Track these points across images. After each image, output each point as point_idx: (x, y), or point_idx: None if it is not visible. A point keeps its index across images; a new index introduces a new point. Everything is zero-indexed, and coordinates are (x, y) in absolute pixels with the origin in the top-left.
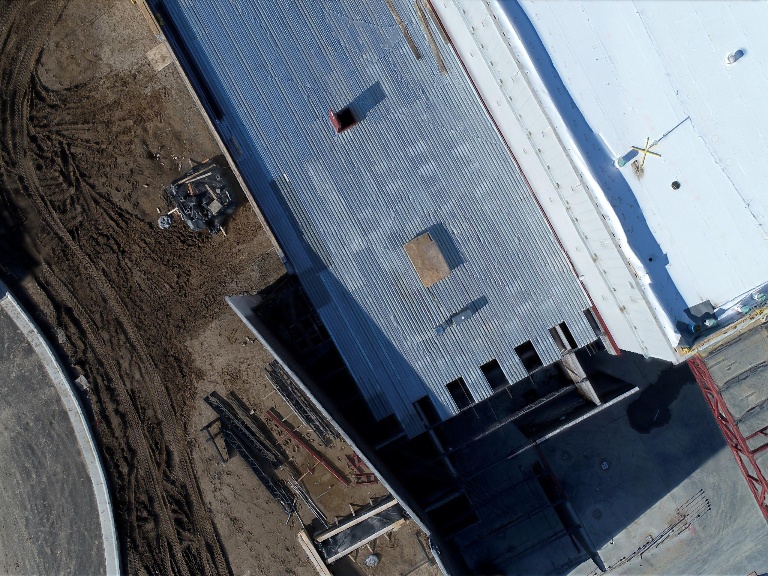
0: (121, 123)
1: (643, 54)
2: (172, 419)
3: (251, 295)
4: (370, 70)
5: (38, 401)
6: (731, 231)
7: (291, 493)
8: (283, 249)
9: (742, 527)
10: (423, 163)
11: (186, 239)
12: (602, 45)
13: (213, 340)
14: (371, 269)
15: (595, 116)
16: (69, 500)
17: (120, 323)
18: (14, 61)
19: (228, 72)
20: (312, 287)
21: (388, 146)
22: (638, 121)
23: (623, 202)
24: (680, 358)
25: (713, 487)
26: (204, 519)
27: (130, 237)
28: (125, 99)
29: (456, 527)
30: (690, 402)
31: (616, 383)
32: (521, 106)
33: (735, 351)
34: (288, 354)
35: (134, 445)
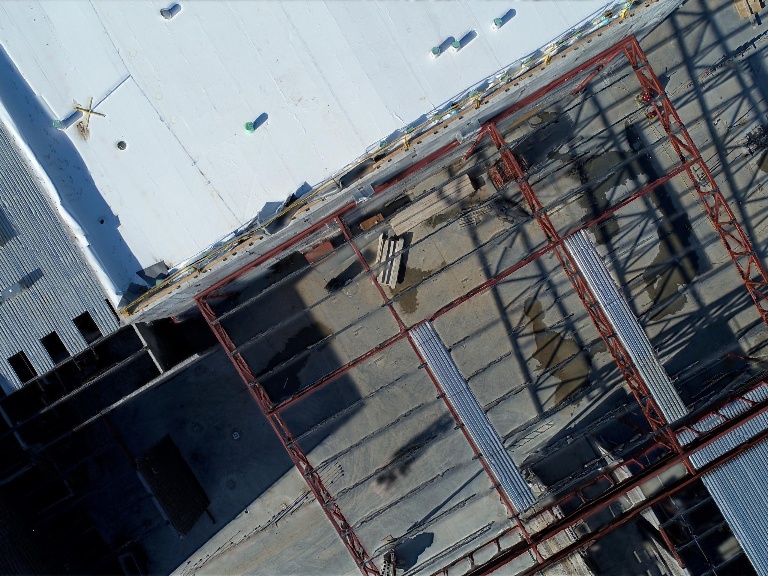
0: None
1: (81, 12)
2: None
3: None
4: None
5: None
6: (180, 190)
7: None
8: None
9: (376, 491)
10: None
11: None
12: (39, 5)
13: None
14: None
15: (36, 78)
16: None
17: None
18: None
19: None
20: None
21: None
22: (81, 81)
23: (70, 165)
24: (125, 320)
25: None
26: None
27: None
28: None
29: (45, 501)
30: (319, 369)
31: None
32: None
33: None
34: None
35: None
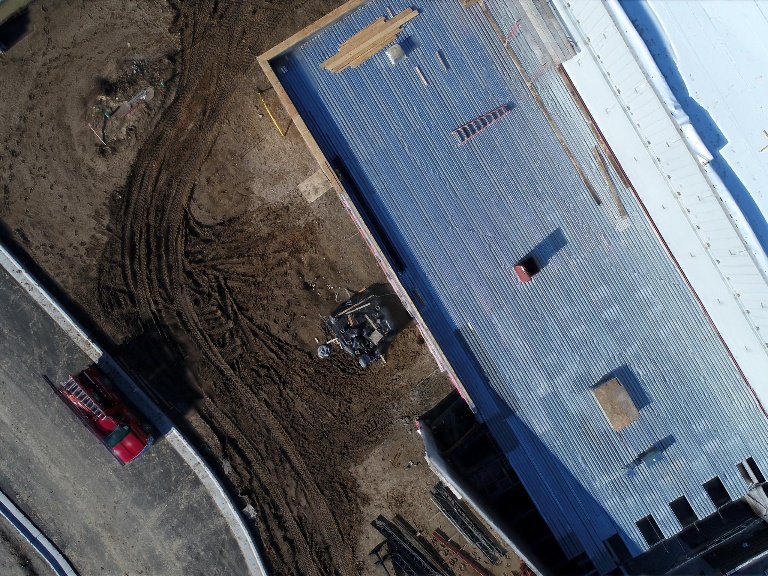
0: (276, 255)
1: None
2: (340, 543)
3: (424, 429)
4: (551, 217)
5: (207, 531)
6: None
7: None
8: (470, 397)
9: None
10: (607, 307)
11: (346, 368)
12: None
13: (377, 465)
14: (558, 413)
15: None
16: None
17: (284, 452)
18: (166, 198)
19: (408, 224)
20: (500, 432)
21: (571, 291)
22: None
23: None
24: None
25: None
26: None
27: (290, 367)
28: (279, 231)
29: None
30: None
31: None
32: (735, 274)
33: None
34: (480, 500)
35: (303, 569)
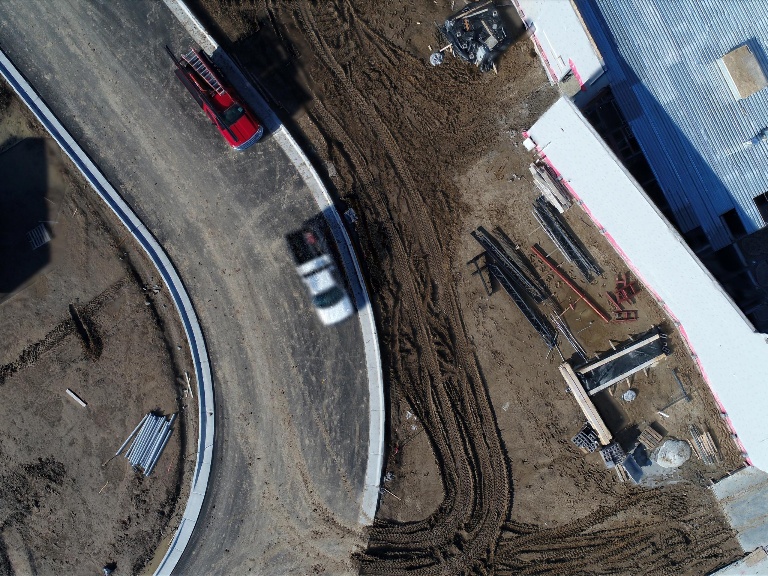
0: None
1: None
2: (438, 253)
3: None
4: None
5: (307, 233)
6: None
7: (552, 328)
8: None
9: None
10: None
11: (457, 76)
12: None
13: (480, 176)
14: (684, 83)
15: None
16: (335, 330)
17: (389, 158)
18: None
19: None
20: (625, 100)
21: None
22: None
23: None
24: None
25: None
26: (466, 351)
27: (402, 73)
28: None
29: None
30: None
31: None
32: None
33: None
34: None
35: (399, 278)
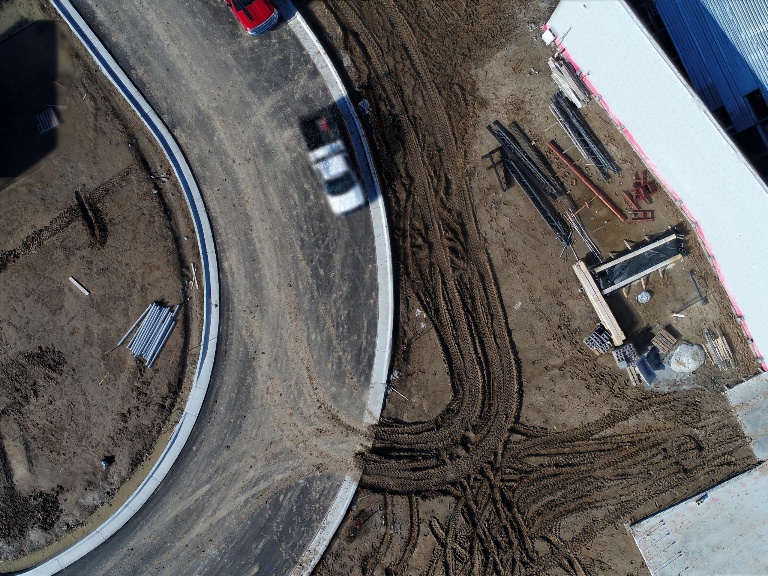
0: None
1: None
2: (452, 147)
3: None
4: None
5: (320, 123)
6: None
7: (567, 226)
8: None
9: None
10: None
11: None
12: None
13: (498, 70)
14: None
15: None
16: (345, 223)
17: (405, 49)
18: None
19: None
20: None
21: None
22: None
23: None
24: None
25: None
26: (478, 248)
27: None
28: None
29: None
30: None
31: None
32: None
33: None
34: None
35: (412, 172)
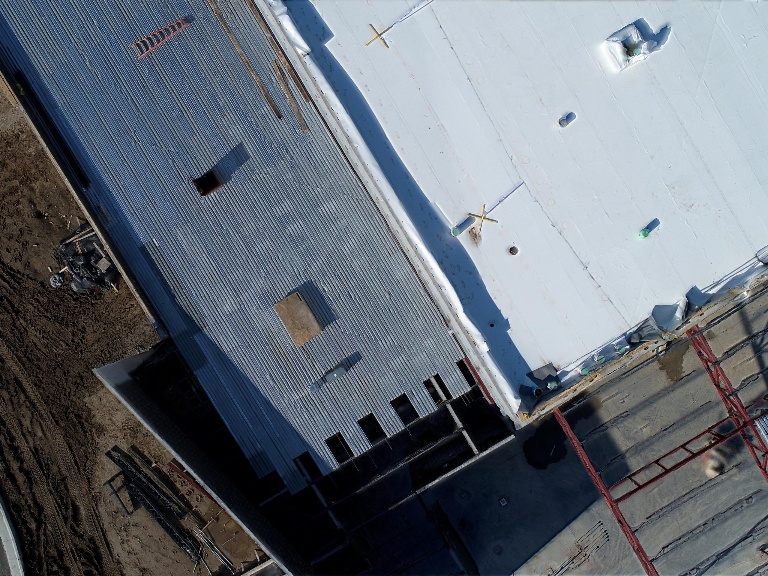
0: (7, 184)
1: (476, 121)
2: (76, 474)
3: (139, 354)
4: (233, 131)
5: None
6: (570, 294)
7: (197, 541)
8: (157, 314)
9: None
10: (291, 222)
11: (79, 297)
12: (434, 113)
13: (111, 395)
14: (245, 330)
15: (430, 185)
16: None
17: (19, 382)
18: None
19: (92, 139)
20: (187, 350)
21: (255, 207)
22: (474, 188)
23: (462, 270)
24: (522, 423)
25: (611, 518)
26: (113, 570)
27: (23, 297)
28: (10, 159)
29: (347, 575)
30: None
31: (499, 428)
32: None
33: (628, 384)
34: (166, 417)
35: (40, 501)
